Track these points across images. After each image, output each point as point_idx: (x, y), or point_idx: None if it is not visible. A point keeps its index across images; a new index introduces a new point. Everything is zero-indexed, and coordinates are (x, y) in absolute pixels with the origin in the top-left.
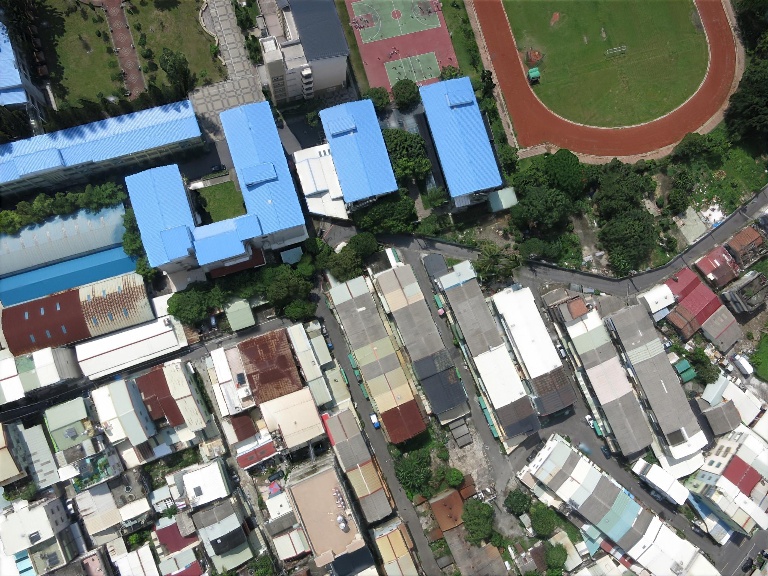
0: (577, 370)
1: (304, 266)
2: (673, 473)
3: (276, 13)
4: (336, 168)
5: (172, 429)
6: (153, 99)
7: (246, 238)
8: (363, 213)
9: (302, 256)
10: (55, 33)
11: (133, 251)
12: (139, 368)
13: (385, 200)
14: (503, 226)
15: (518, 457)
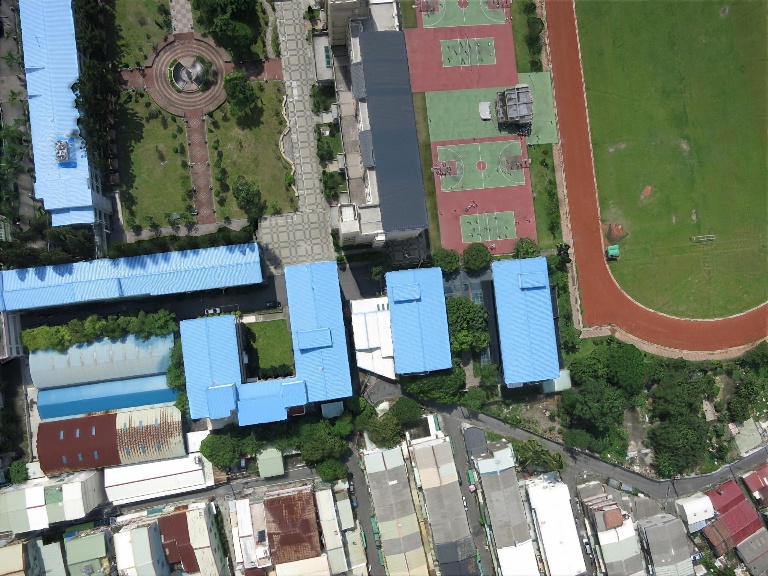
0: (600, 571)
1: (343, 425)
2: None
3: (359, 153)
4: (393, 336)
5: None
6: (220, 240)
7: (291, 405)
8: (412, 380)
9: (342, 414)
10: (132, 138)
11: (176, 386)
12: (163, 497)
13: (436, 373)
14: (551, 407)
15: None
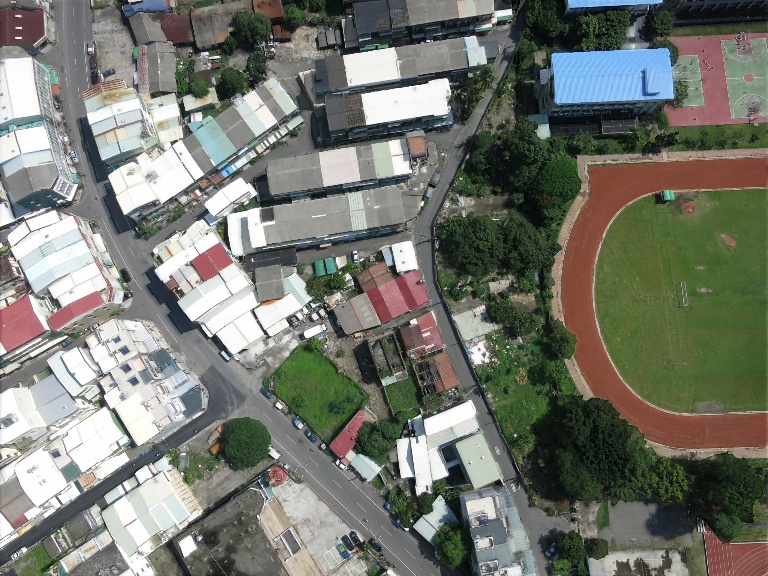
0: None
1: None
2: (234, 219)
3: None
4: None
5: None
6: None
7: None
8: None
9: None
10: None
11: None
12: None
13: (560, 2)
14: (512, 127)
15: (293, 87)
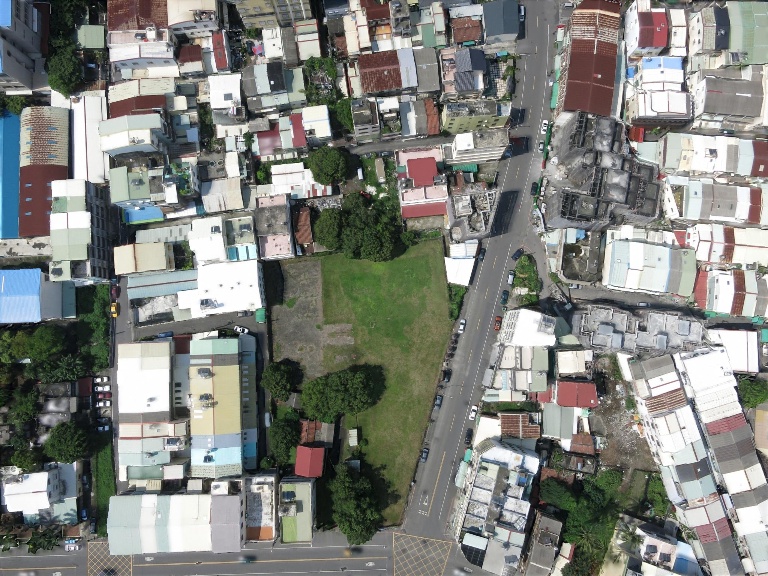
0: None
1: None
2: None
3: None
4: None
5: (175, 120)
6: None
7: None
8: None
9: None
10: None
11: None
12: None
13: None
14: None
15: None
